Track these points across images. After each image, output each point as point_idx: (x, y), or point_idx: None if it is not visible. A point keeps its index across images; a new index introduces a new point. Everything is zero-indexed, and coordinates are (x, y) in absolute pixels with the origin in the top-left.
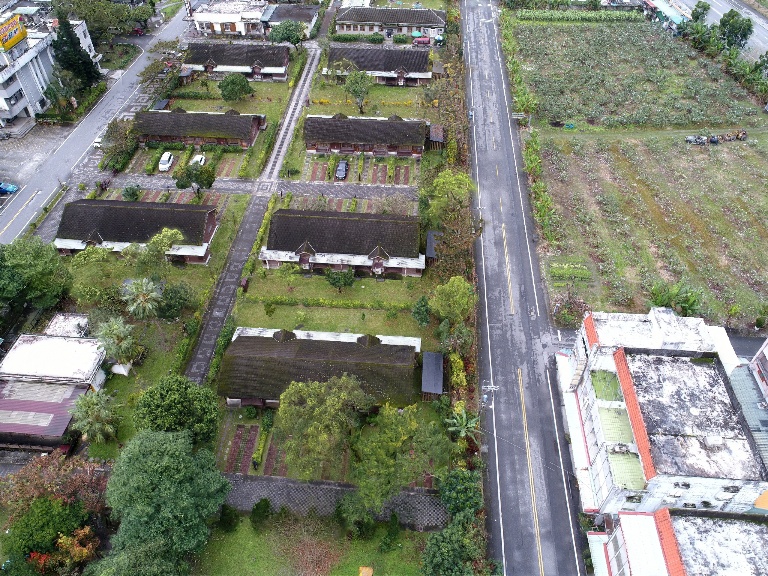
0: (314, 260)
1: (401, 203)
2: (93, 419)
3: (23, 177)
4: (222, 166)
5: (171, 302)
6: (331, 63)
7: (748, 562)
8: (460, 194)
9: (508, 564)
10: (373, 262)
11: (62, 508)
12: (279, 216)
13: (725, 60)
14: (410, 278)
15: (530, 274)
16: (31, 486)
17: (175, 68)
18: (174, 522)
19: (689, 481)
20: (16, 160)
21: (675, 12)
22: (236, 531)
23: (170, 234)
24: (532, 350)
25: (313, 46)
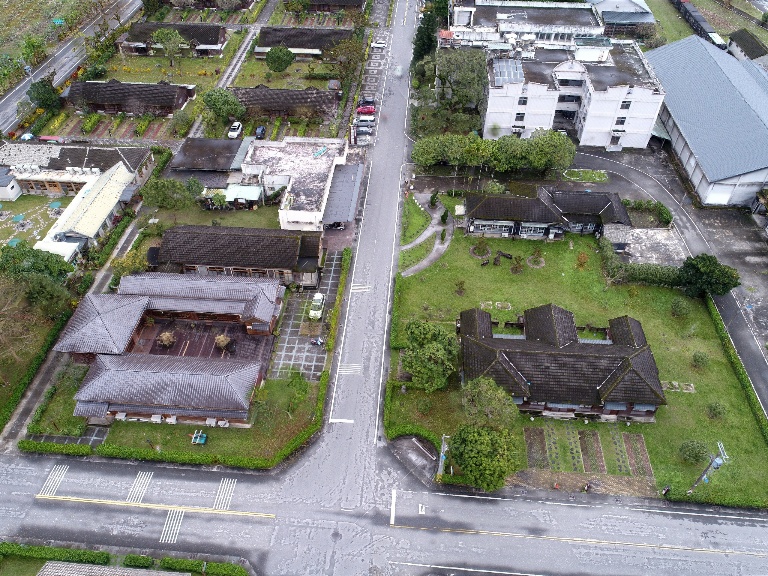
0: None
1: None
2: None
3: None
4: None
5: None
6: None
7: None
8: None
9: None
10: None
11: None
12: None
13: None
14: None
15: None
16: None
17: None
18: None
19: None
20: None
21: None
22: None
23: None
24: None
25: None
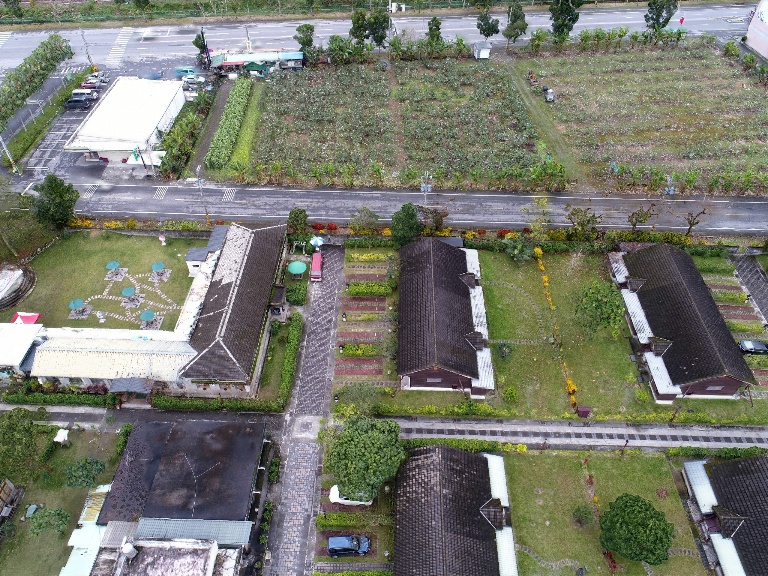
0: None
1: None
2: None
3: None
4: None
5: None
6: (468, 370)
7: None
8: (735, 243)
9: None
10: None
11: None
12: None
13: None
14: None
15: None
16: None
17: None
18: None
19: None
20: None
21: (271, 53)
22: None
23: None
24: None
25: (311, 436)
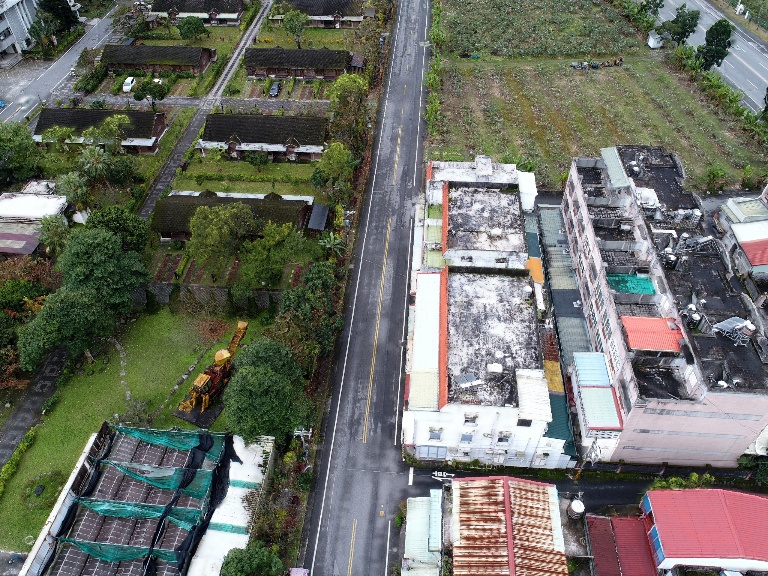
0: (240, 148)
1: (315, 107)
2: (53, 234)
3: (10, 97)
4: (176, 88)
5: (119, 169)
6: (277, 9)
7: (497, 295)
8: (371, 106)
9: (353, 330)
10: (287, 150)
11: (27, 283)
12: (213, 115)
13: (621, 4)
14: (317, 163)
15: (414, 159)
16: (6, 272)
17: (142, 13)
18: (104, 283)
19: (471, 255)
20: (5, 85)
21: None
22: (158, 314)
23: (119, 118)
24: (403, 207)
25: None
